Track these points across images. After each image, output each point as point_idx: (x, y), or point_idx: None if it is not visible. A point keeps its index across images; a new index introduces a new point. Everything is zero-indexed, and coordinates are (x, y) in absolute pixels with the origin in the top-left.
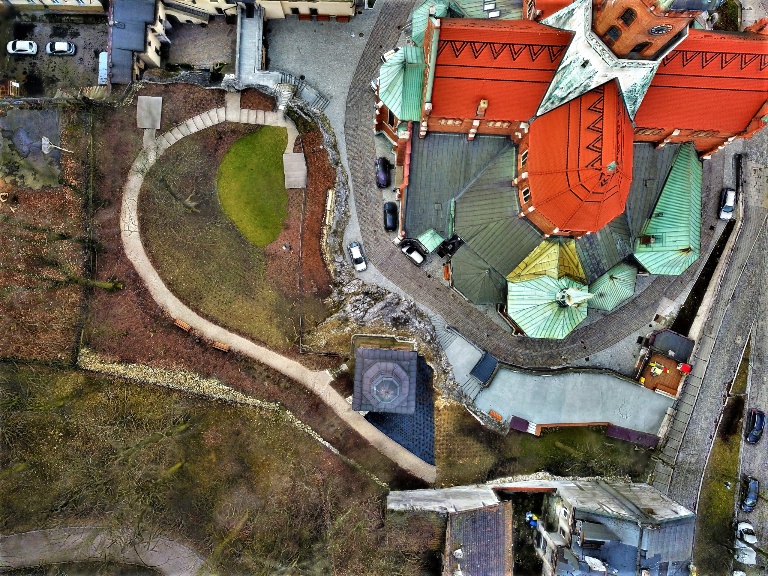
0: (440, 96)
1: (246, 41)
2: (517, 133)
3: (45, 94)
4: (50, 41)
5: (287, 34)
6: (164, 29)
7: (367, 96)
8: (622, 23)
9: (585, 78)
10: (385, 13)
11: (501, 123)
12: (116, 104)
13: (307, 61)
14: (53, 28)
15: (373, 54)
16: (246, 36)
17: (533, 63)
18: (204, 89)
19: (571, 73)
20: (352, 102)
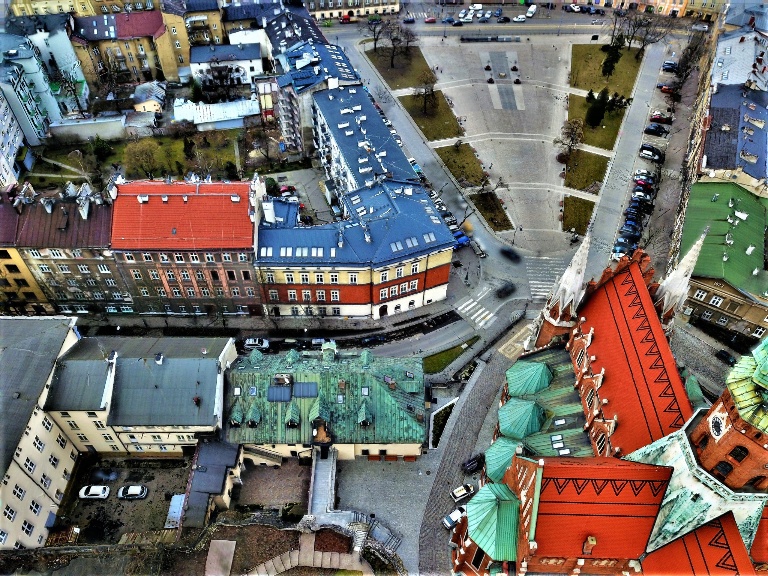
0: (543, 534)
1: (319, 481)
2: (624, 572)
3: (104, 540)
4: (123, 485)
5: (356, 473)
6: (240, 471)
7: (440, 534)
8: (731, 459)
9: (698, 512)
10: (449, 452)
11: (607, 561)
12: (188, 549)
13: (377, 499)
14: (130, 473)
15: (442, 491)
16: (319, 476)
17: (636, 498)
18: (279, 531)
19: (680, 507)
20: (425, 541)
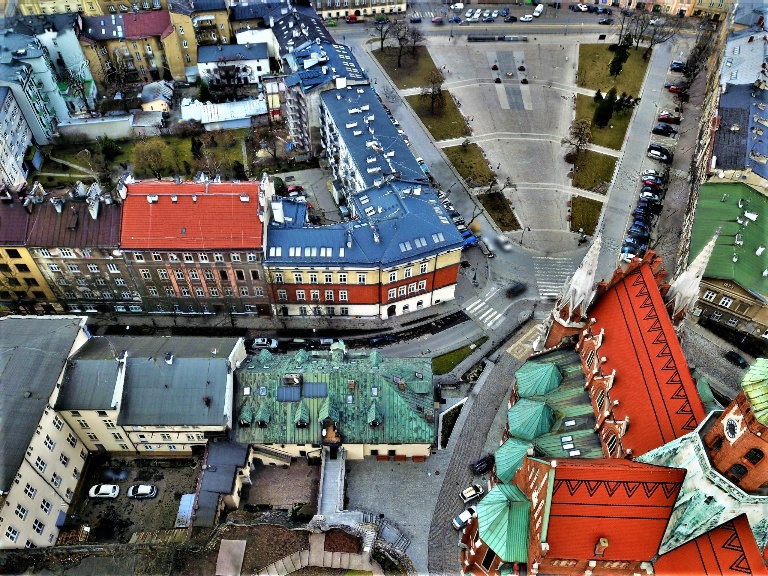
0: (555, 535)
1: (328, 481)
2: (636, 574)
3: (114, 538)
4: (133, 484)
5: (365, 474)
6: (249, 471)
7: (449, 534)
8: (746, 462)
9: (711, 514)
10: (458, 453)
11: (618, 563)
12: (198, 549)
13: (386, 499)
14: (139, 472)
15: (451, 491)
16: (329, 476)
17: (648, 500)
18: (289, 531)
19: (693, 509)
20: (434, 541)
